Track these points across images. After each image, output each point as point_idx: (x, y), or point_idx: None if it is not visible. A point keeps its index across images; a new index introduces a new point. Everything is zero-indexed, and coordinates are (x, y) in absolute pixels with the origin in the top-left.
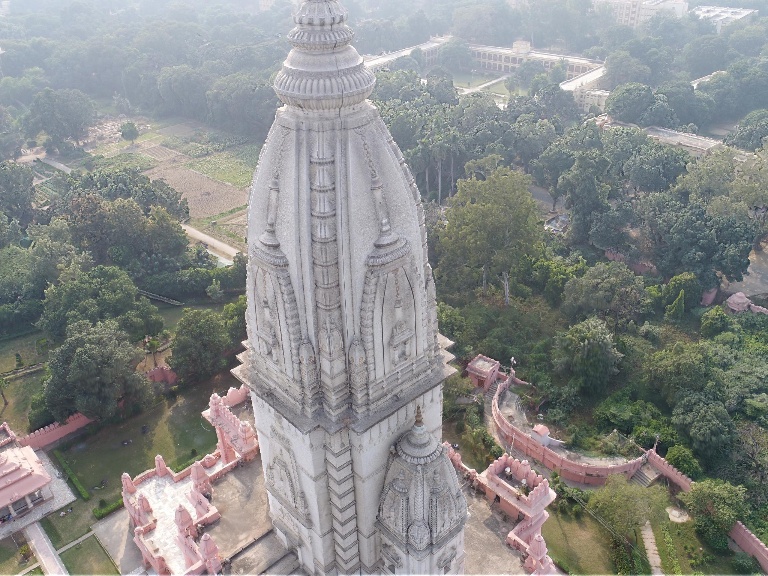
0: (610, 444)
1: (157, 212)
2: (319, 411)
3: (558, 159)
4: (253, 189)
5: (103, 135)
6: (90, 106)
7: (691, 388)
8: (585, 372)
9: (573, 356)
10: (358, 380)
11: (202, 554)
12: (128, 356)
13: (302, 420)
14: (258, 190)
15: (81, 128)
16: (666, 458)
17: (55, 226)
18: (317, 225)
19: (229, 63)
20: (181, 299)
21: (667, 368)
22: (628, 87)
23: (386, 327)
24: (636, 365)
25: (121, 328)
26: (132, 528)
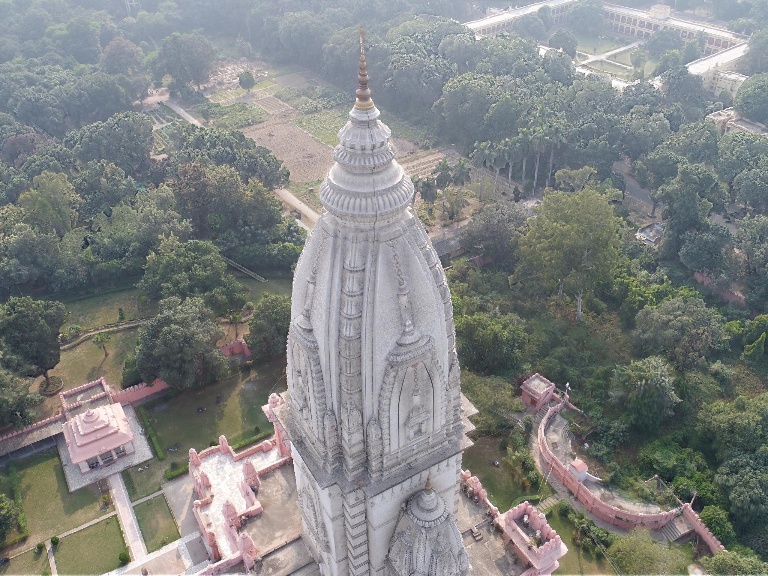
0: (646, 491)
1: (254, 186)
2: (338, 468)
3: (663, 164)
4: (297, 271)
5: (223, 80)
6: (212, 53)
7: (742, 448)
8: (638, 410)
9: (629, 392)
10: (373, 452)
11: (240, 548)
12: (209, 335)
13: (322, 475)
14: (300, 276)
15: (203, 73)
16: (700, 516)
17: (162, 194)
18: (344, 324)
19: (350, 12)
20: (268, 270)
21: (721, 424)
22: (762, 82)
23: (403, 411)
24: (697, 405)
25: (207, 304)
26: (195, 494)
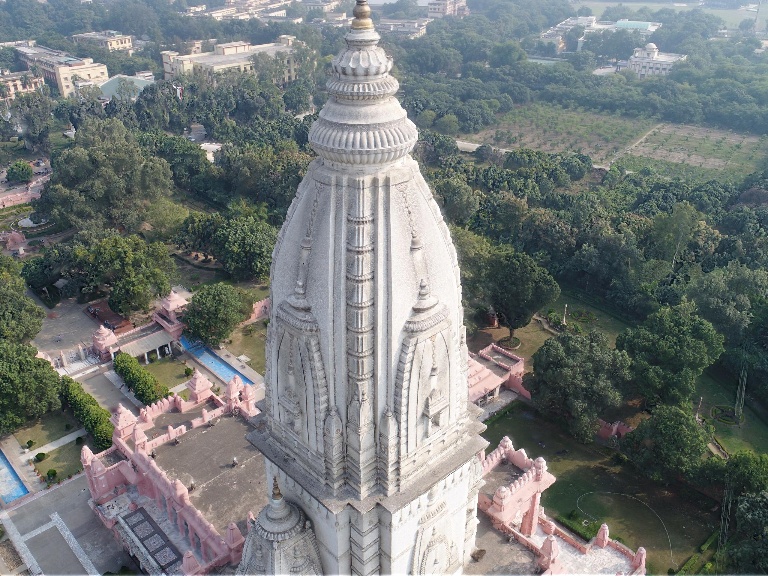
0: None
1: None
2: None
3: None
4: None
5: None
6: None
7: None
8: None
9: None
10: None
11: None
12: None
13: None
14: None
15: None
16: None
17: None
18: None
19: None
20: None
21: None
22: None
23: None
24: None
25: (635, 371)
26: None
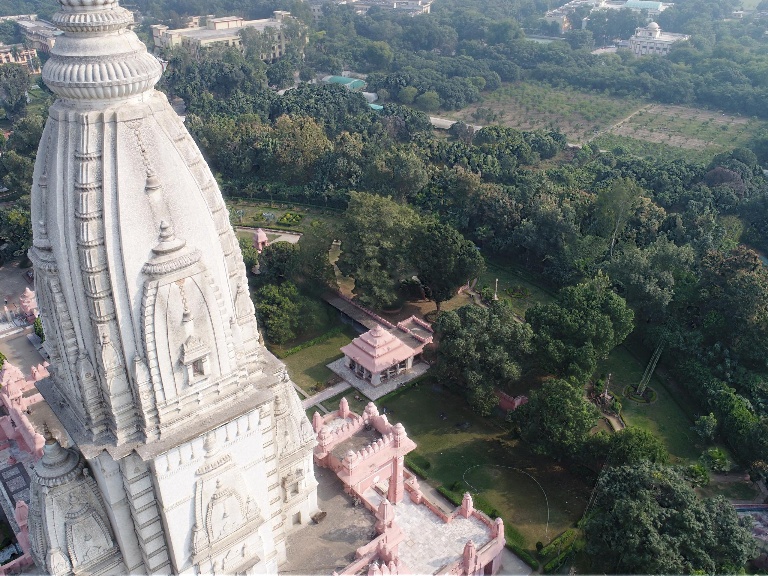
0: None
1: None
2: None
3: None
4: None
5: None
6: None
7: None
8: None
9: None
10: None
11: None
12: None
13: None
14: None
15: None
16: None
17: None
18: None
19: None
20: (699, 408)
21: None
22: None
23: None
24: None
25: (537, 344)
26: None
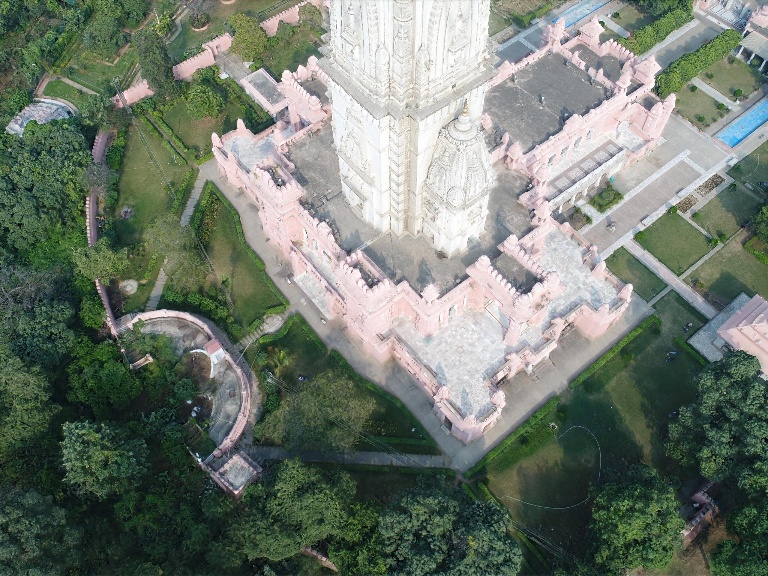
0: (150, 335)
1: None
2: None
3: None
4: None
5: None
6: None
7: None
8: None
9: None
10: None
11: None
12: None
13: None
14: None
15: None
16: None
17: None
18: None
19: None
20: None
21: None
22: None
23: None
24: None
25: (759, 496)
26: None
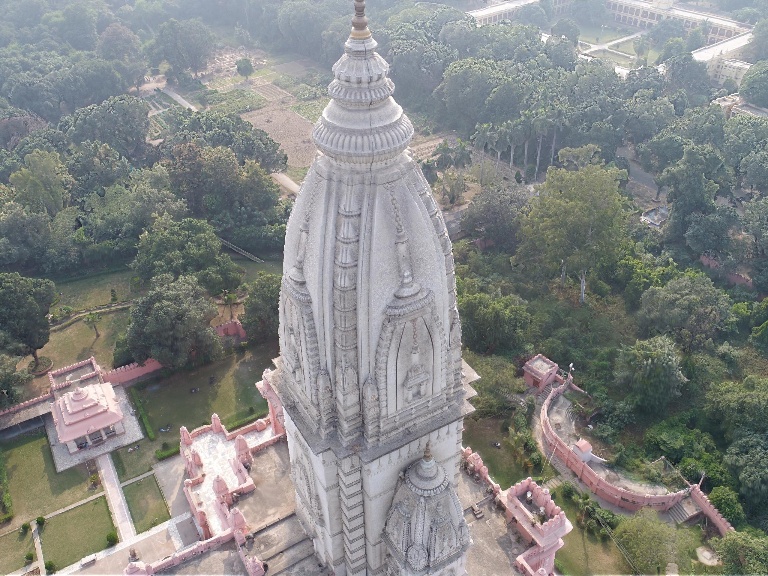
0: (653, 472)
1: (251, 166)
2: (333, 433)
3: (668, 147)
4: None
5: (221, 67)
6: (210, 39)
7: (752, 428)
8: (644, 391)
9: (634, 372)
10: (369, 414)
11: (231, 524)
12: (202, 313)
13: (316, 440)
14: (292, 226)
15: (200, 60)
16: (709, 497)
17: (156, 173)
18: (338, 274)
19: (350, 0)
20: (265, 252)
21: (730, 404)
22: None
23: (401, 370)
24: (704, 387)
25: (201, 283)
26: (186, 474)
